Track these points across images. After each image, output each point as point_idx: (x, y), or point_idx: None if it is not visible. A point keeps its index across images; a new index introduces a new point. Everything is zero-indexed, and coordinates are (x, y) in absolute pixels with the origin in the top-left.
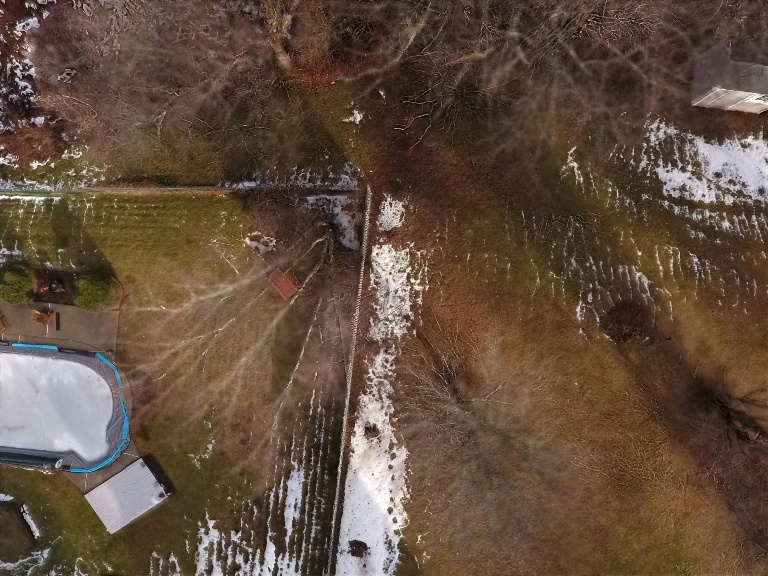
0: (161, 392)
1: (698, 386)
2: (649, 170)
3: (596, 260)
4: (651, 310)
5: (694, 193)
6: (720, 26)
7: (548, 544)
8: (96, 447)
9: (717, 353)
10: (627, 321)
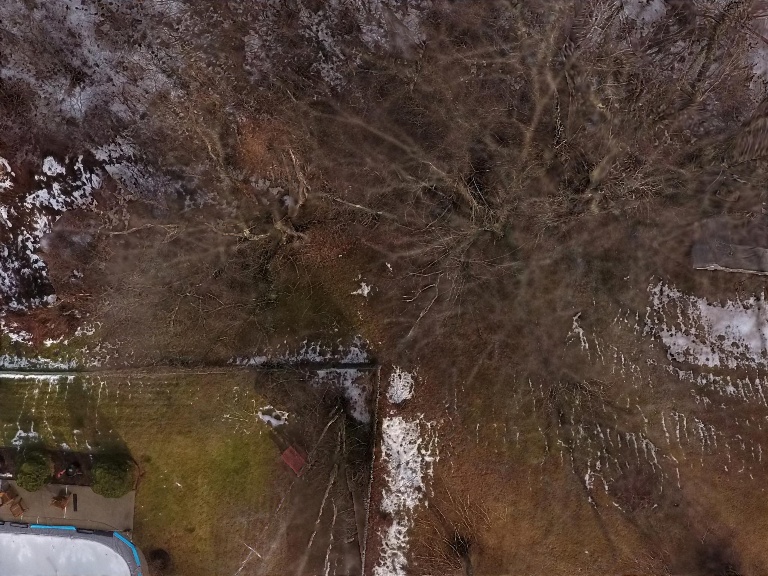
0: (178, 568)
1: (706, 553)
2: (653, 334)
3: (603, 428)
4: (658, 477)
5: (698, 357)
6: (720, 190)
7: None
8: None
9: (724, 519)
10: (635, 490)
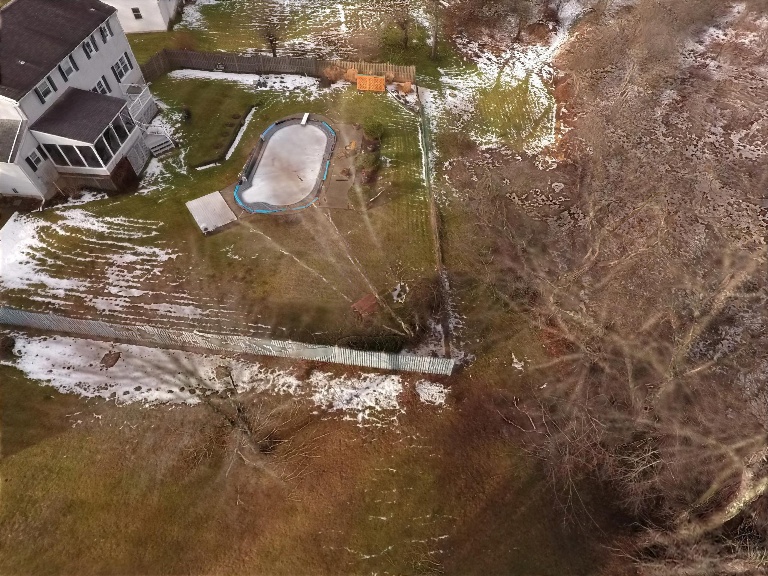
0: (285, 230)
1: None
2: None
3: None
4: None
5: None
6: None
7: (29, 573)
8: (251, 197)
9: None
10: None
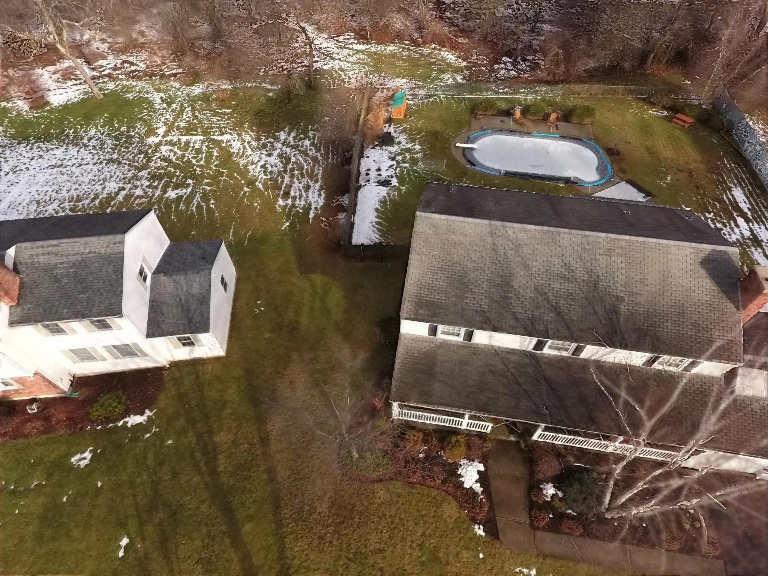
0: (627, 155)
1: None
2: None
3: None
4: None
5: None
6: None
7: None
8: (591, 176)
9: None
10: None
